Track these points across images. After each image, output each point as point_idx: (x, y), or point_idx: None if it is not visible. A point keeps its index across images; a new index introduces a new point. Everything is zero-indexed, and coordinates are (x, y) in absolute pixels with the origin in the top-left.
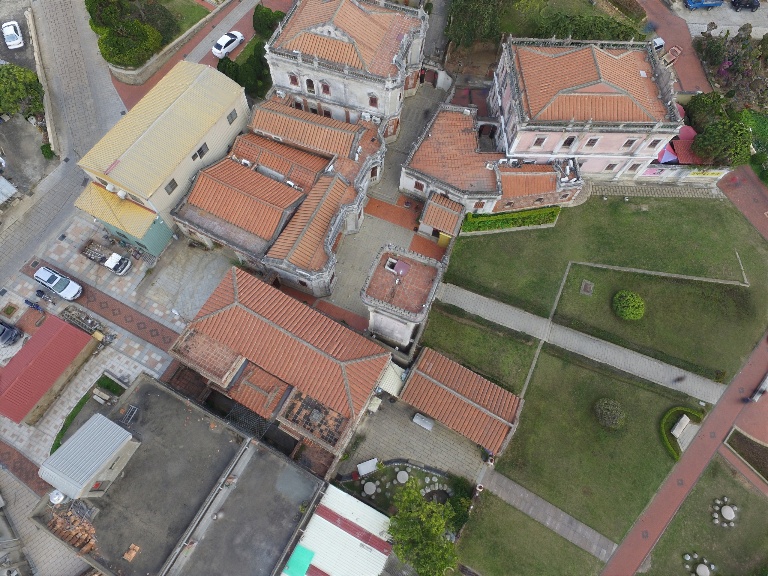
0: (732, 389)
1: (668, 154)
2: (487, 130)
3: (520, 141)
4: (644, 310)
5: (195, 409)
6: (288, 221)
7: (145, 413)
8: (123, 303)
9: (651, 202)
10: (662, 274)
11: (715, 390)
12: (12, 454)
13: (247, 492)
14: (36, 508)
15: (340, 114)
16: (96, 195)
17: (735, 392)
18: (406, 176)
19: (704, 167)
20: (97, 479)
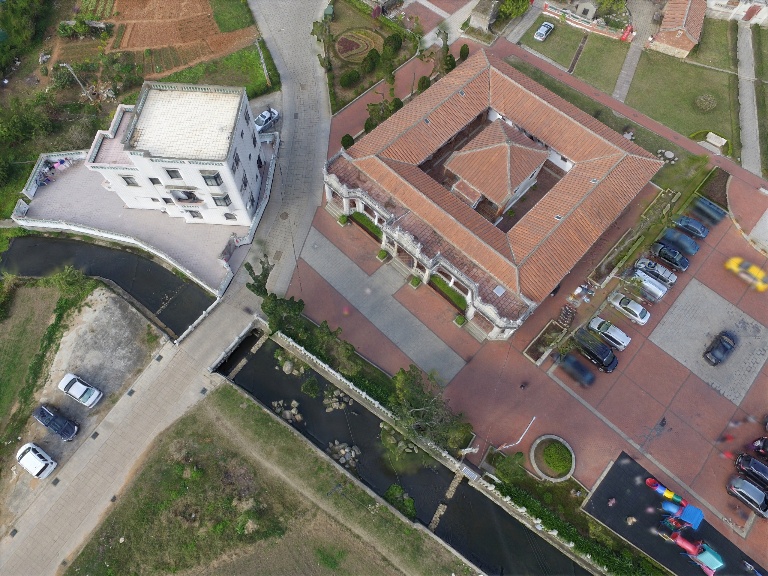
0: (761, 180)
1: None
2: None
3: None
4: None
5: None
6: None
7: None
8: None
9: None
10: None
11: (754, 169)
12: None
13: None
14: None
15: None
16: None
17: (759, 181)
18: None
19: None
20: None
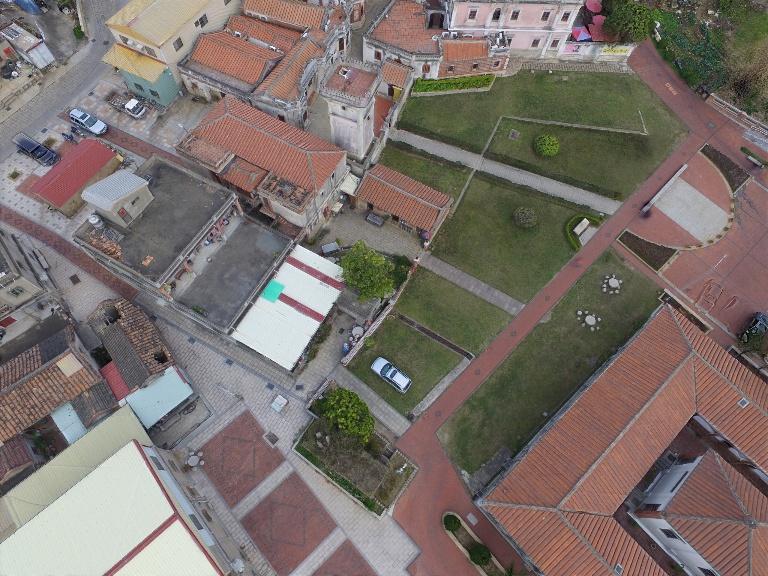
0: (627, 205)
1: (583, 34)
2: (438, 22)
3: (457, 14)
4: (560, 151)
5: (195, 178)
6: (270, 71)
7: (158, 180)
8: (139, 139)
9: (571, 75)
10: (576, 125)
11: (613, 205)
12: (53, 236)
13: (234, 247)
14: (78, 230)
15: (315, 2)
16: (119, 52)
17: (629, 207)
18: (367, 47)
19: (612, 43)
20: (123, 205)
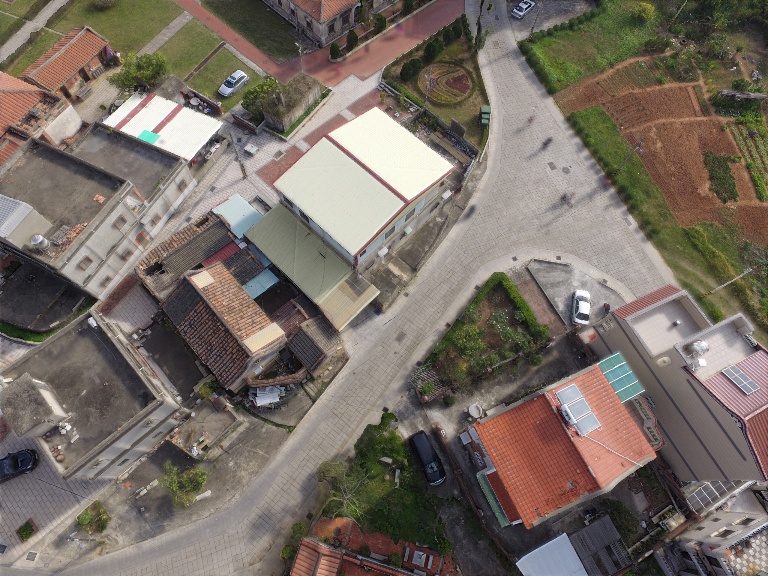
0: None
1: None
2: None
3: None
4: None
5: (1, 178)
6: None
7: None
8: None
9: None
10: None
11: None
12: None
13: None
14: (47, 261)
15: None
16: None
17: None
18: None
19: None
20: None
